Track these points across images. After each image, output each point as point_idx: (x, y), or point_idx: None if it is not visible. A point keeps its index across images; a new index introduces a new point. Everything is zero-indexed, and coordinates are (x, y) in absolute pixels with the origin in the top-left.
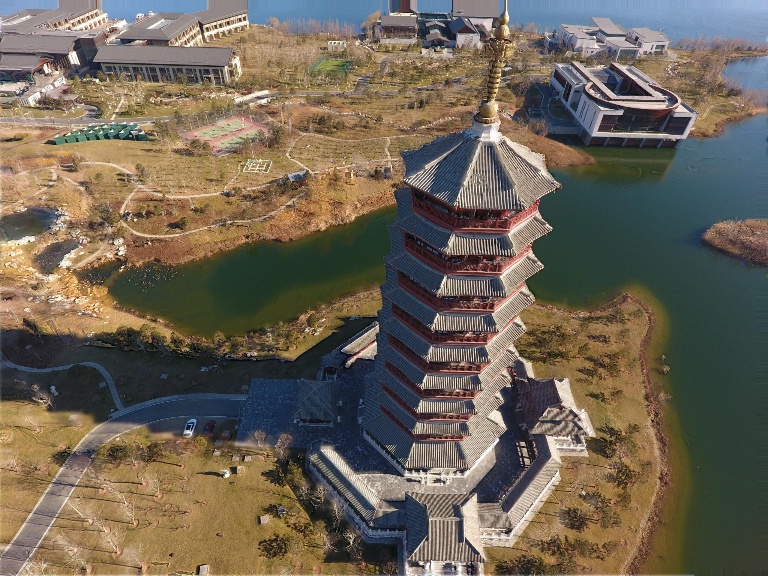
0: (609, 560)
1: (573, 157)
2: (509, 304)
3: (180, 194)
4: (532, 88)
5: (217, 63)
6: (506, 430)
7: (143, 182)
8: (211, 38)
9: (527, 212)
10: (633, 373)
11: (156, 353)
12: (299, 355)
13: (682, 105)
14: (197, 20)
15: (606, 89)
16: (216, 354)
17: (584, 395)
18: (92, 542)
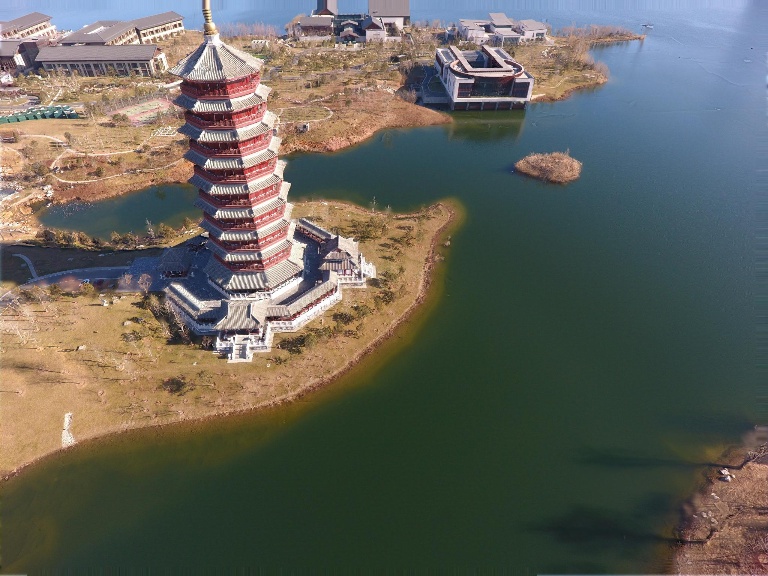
0: (362, 339)
1: (436, 118)
2: (259, 156)
3: (100, 153)
4: (418, 70)
5: (143, 57)
6: (311, 275)
7: (71, 147)
8: (148, 42)
9: (243, 88)
10: (423, 247)
11: (67, 249)
12: (175, 245)
13: (525, 73)
14: (134, 26)
15: (467, 64)
16: (114, 249)
17: (377, 257)
18: (8, 340)
